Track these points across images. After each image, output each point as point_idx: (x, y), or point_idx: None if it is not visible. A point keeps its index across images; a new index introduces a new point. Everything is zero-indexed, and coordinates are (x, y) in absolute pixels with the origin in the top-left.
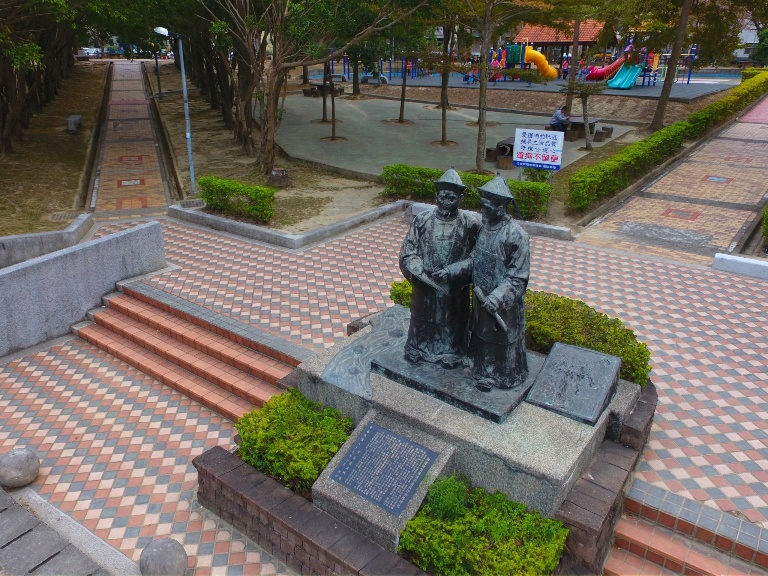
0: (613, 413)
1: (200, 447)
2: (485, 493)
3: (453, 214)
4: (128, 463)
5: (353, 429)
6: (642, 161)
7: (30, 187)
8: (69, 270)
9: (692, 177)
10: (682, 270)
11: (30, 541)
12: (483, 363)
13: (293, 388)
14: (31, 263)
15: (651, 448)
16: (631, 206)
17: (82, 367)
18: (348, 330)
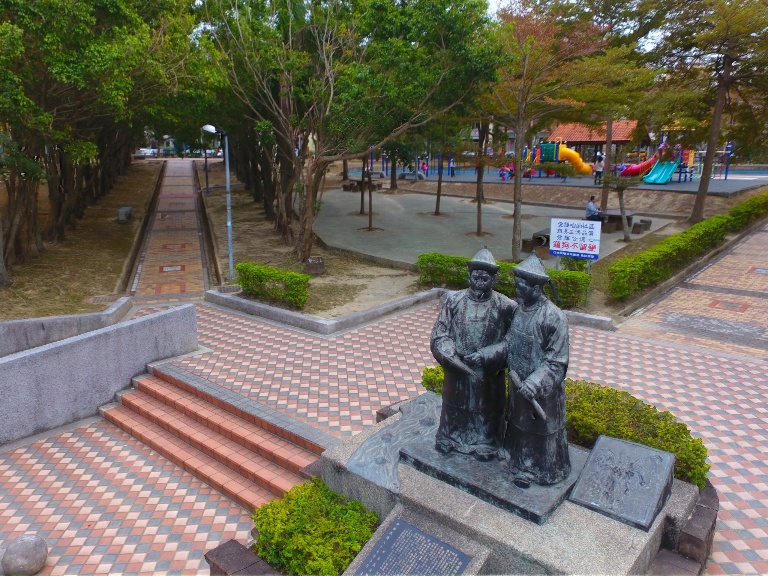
0: (669, 517)
1: (216, 540)
2: None
3: (487, 295)
4: (139, 555)
5: (378, 526)
6: (684, 252)
7: (76, 271)
8: (102, 350)
9: (738, 269)
10: (735, 363)
11: None
12: (520, 455)
13: (316, 478)
14: (65, 342)
15: (715, 561)
16: (675, 297)
17: (104, 450)
18: (377, 417)
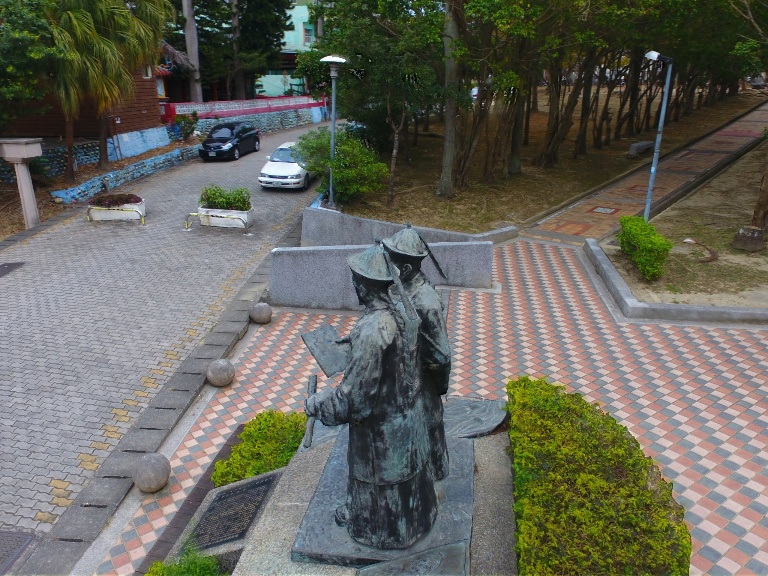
0: None
1: None
2: None
3: None
4: None
5: None
6: None
7: (519, 197)
8: None
9: None
10: None
11: (165, 414)
12: None
13: None
14: None
15: None
16: None
17: None
18: None
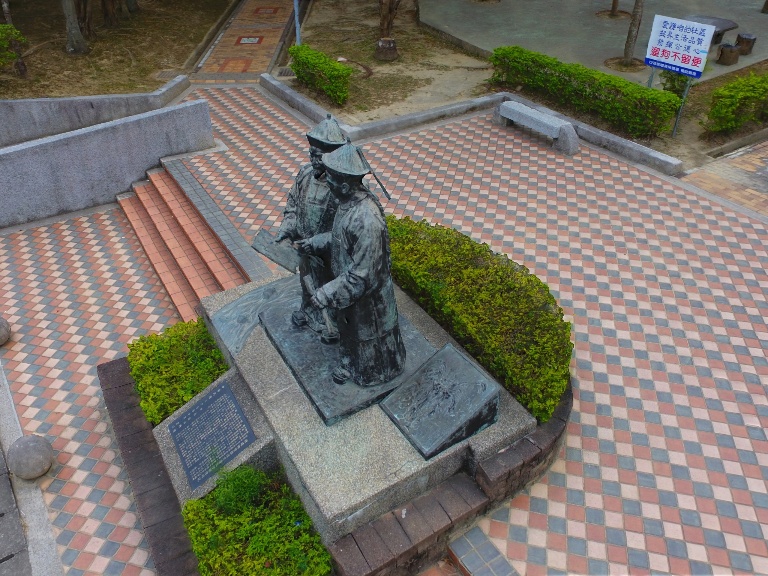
0: (470, 448)
1: None
2: (289, 493)
3: None
4: (80, 347)
5: None
6: None
7: (158, 39)
8: (111, 143)
9: None
10: None
11: None
12: None
13: (201, 318)
14: (74, 134)
15: (530, 492)
16: None
17: (105, 239)
18: None
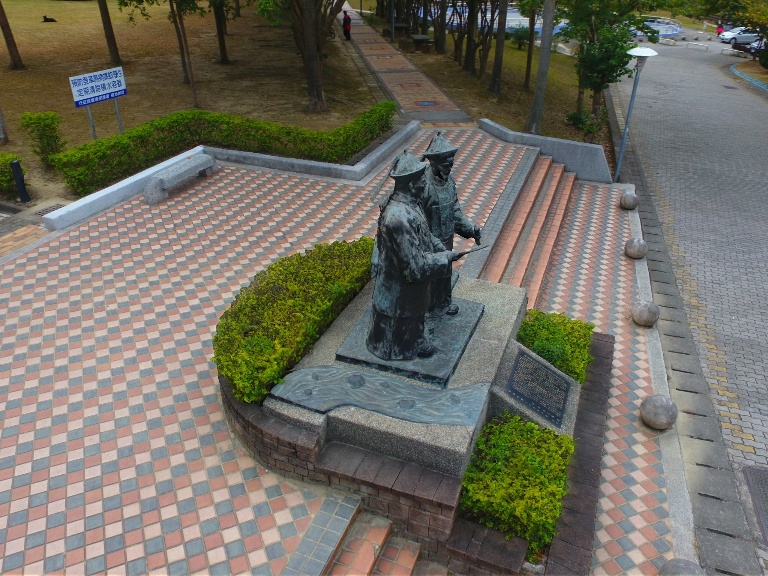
0: None
1: None
2: None
3: None
4: None
5: None
6: None
7: None
8: None
9: None
10: (58, 245)
11: None
12: None
13: (464, 482)
14: None
15: None
16: None
17: None
18: None
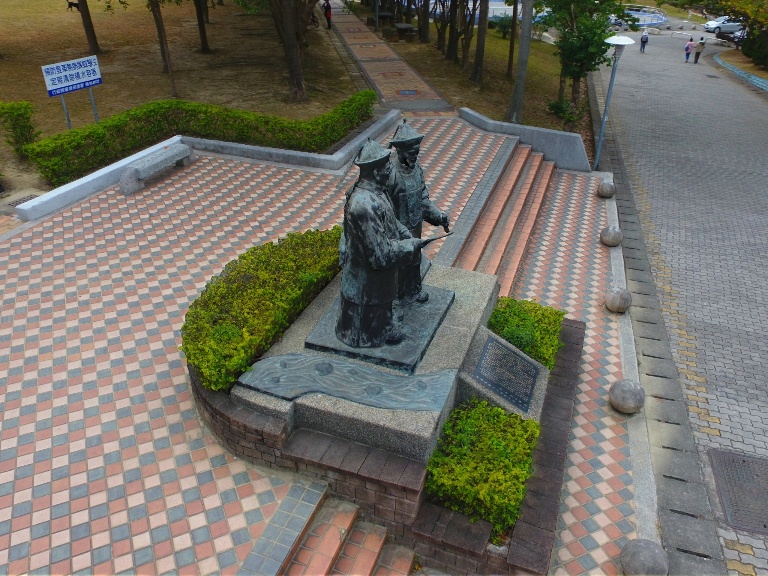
0: None
1: None
2: None
3: None
4: None
5: None
6: None
7: None
8: None
9: None
10: (31, 236)
11: None
12: None
13: (429, 466)
14: None
15: None
16: None
17: None
18: None
